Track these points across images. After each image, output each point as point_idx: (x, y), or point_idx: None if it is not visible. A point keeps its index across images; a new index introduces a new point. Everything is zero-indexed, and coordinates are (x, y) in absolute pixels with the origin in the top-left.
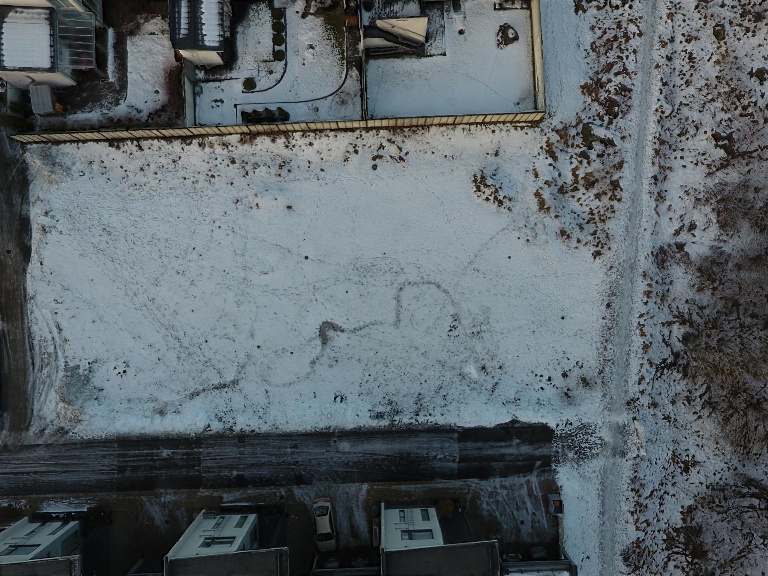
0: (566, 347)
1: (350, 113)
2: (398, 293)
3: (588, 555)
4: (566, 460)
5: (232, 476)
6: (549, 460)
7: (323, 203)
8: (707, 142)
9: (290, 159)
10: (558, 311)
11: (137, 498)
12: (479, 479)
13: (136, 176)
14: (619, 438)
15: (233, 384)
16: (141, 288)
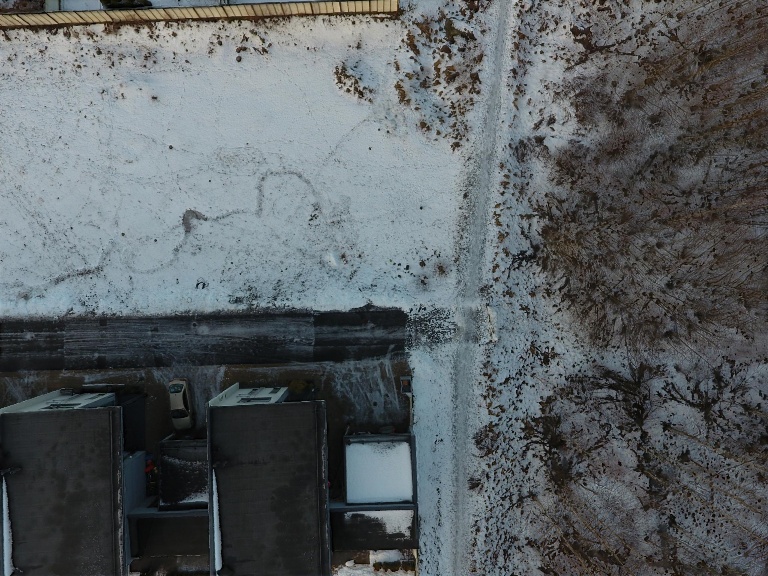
0: (424, 237)
1: (211, 3)
2: (260, 183)
3: (442, 438)
4: (419, 344)
5: (94, 358)
6: (402, 344)
7: (187, 94)
8: (566, 37)
9: (155, 50)
10: (417, 202)
11: (1, 378)
12: (334, 362)
13: (4, 66)
14: (472, 324)
15: (98, 270)
16: (8, 176)
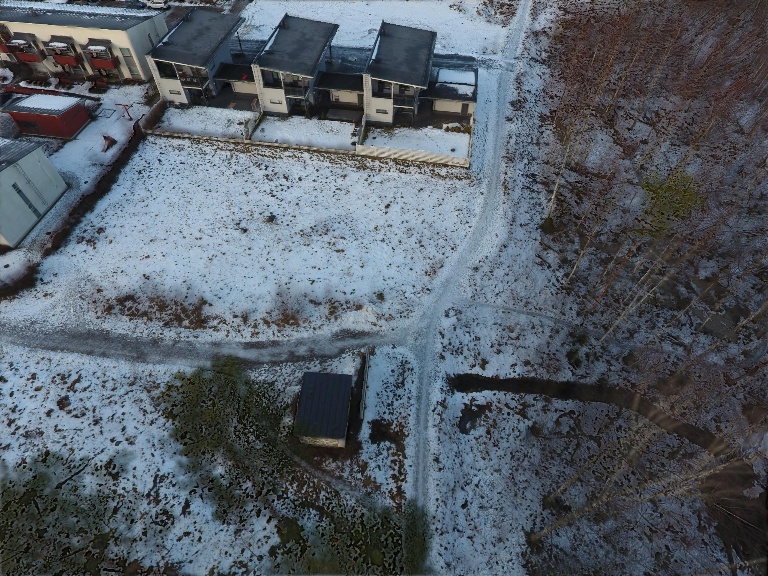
0: (486, 46)
1: None
2: None
3: None
4: (481, 67)
5: None
6: None
7: (382, 5)
8: None
9: None
10: None
11: None
12: (434, 67)
13: None
14: None
15: None
16: (294, 13)
